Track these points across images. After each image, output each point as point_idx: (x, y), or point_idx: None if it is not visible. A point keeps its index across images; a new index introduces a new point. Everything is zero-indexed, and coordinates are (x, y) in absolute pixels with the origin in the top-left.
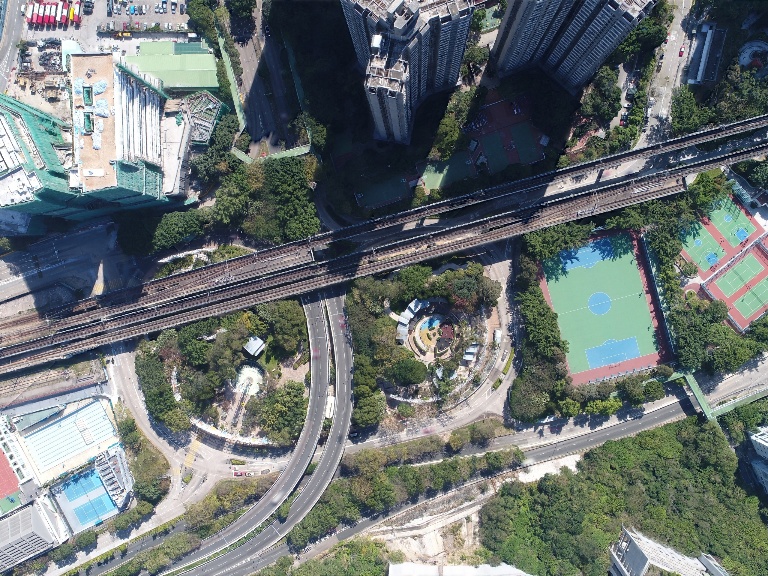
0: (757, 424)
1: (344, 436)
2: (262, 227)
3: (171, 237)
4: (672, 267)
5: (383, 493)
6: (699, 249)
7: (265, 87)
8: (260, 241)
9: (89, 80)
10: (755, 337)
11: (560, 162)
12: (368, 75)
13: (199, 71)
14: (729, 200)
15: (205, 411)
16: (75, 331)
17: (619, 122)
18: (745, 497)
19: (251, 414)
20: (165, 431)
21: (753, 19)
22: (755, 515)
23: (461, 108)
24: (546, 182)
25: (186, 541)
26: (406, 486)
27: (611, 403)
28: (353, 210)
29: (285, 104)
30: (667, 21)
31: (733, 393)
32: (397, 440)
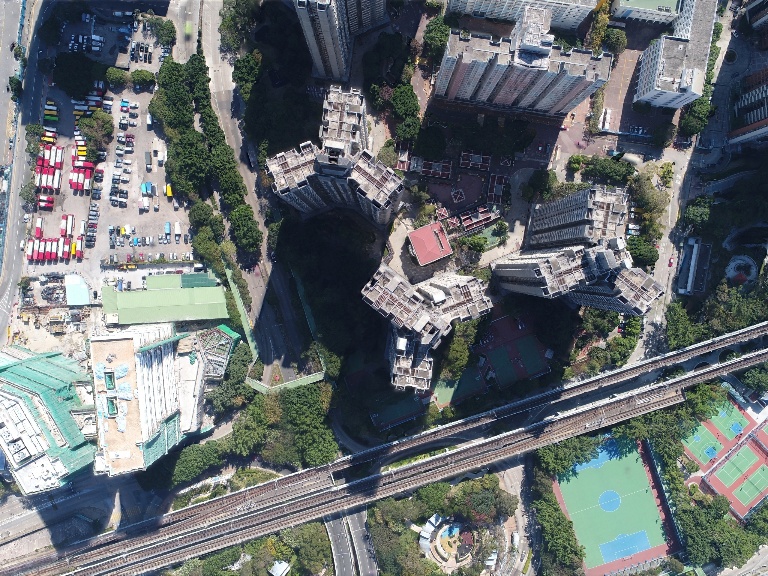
0: None
1: None
2: (281, 454)
3: (191, 473)
4: (676, 467)
5: None
6: (698, 444)
7: (274, 312)
8: None
9: (110, 365)
10: (756, 531)
11: (565, 375)
12: (395, 374)
13: (208, 304)
14: None
15: None
16: (96, 567)
17: (617, 329)
18: None
19: None
20: None
21: (734, 232)
22: None
23: (470, 334)
24: (554, 399)
25: None
26: None
27: None
28: (370, 432)
29: (295, 327)
30: (656, 238)
31: None
32: None
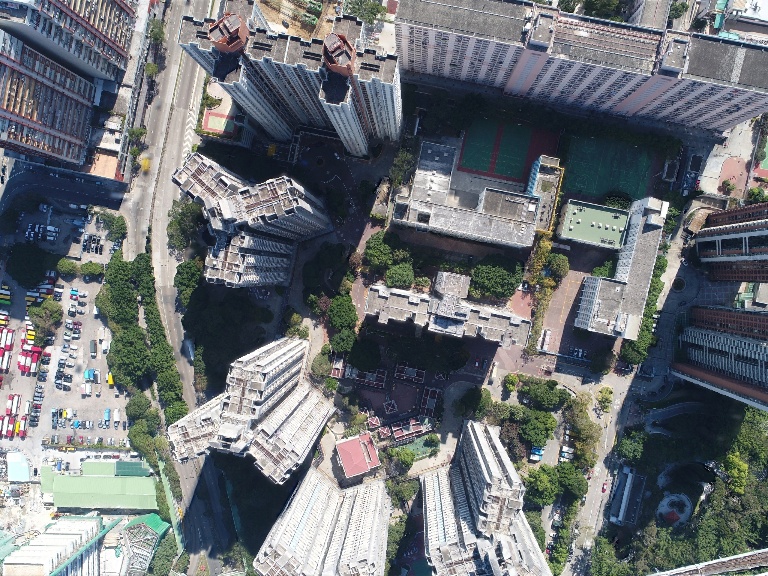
0: None
1: None
2: None
3: None
4: None
5: None
6: None
7: (204, 503)
8: None
9: None
10: None
11: None
12: None
13: (139, 495)
14: None
15: None
16: None
17: None
18: None
19: None
20: None
21: (671, 464)
22: None
23: (390, 551)
24: None
25: None
26: None
27: None
28: None
29: None
30: (589, 466)
31: None
32: None
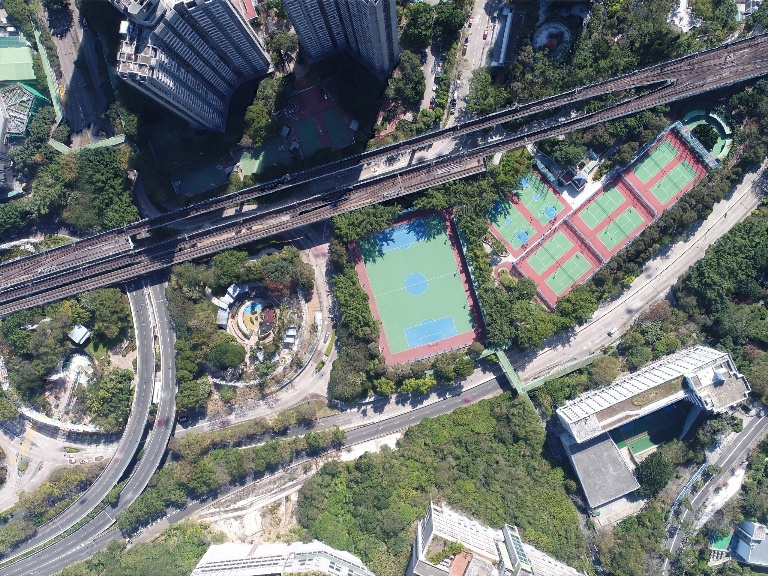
0: (566, 398)
1: (170, 421)
2: (81, 217)
3: None
4: (480, 246)
5: (204, 475)
6: (510, 228)
7: (84, 79)
8: (85, 231)
9: None
10: (559, 312)
11: (369, 146)
12: (119, 61)
13: (15, 64)
14: (537, 179)
15: (33, 400)
16: None
17: (429, 105)
18: (550, 469)
19: (80, 401)
20: (0, 421)
21: (551, 1)
22: (560, 486)
23: (267, 94)
24: (352, 165)
25: (20, 528)
26: (228, 468)
27: (423, 381)
28: (170, 198)
29: None
30: (467, 5)
31: (547, 368)
32: (226, 424)
